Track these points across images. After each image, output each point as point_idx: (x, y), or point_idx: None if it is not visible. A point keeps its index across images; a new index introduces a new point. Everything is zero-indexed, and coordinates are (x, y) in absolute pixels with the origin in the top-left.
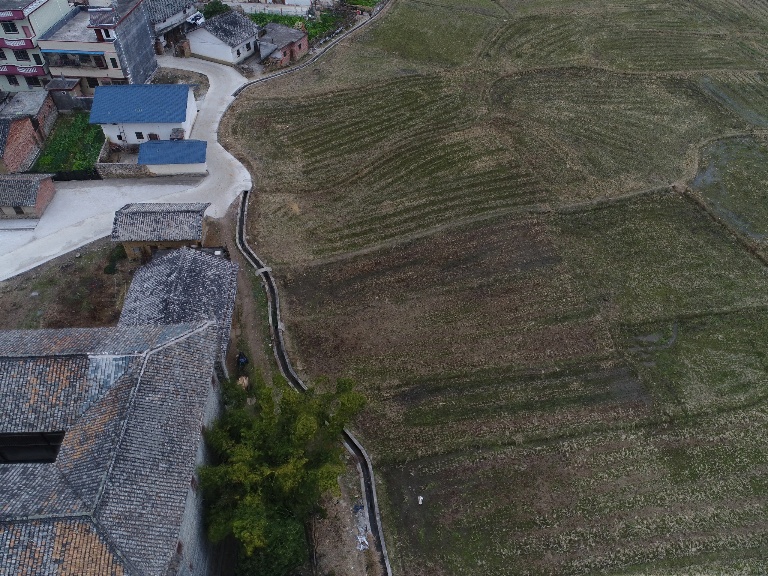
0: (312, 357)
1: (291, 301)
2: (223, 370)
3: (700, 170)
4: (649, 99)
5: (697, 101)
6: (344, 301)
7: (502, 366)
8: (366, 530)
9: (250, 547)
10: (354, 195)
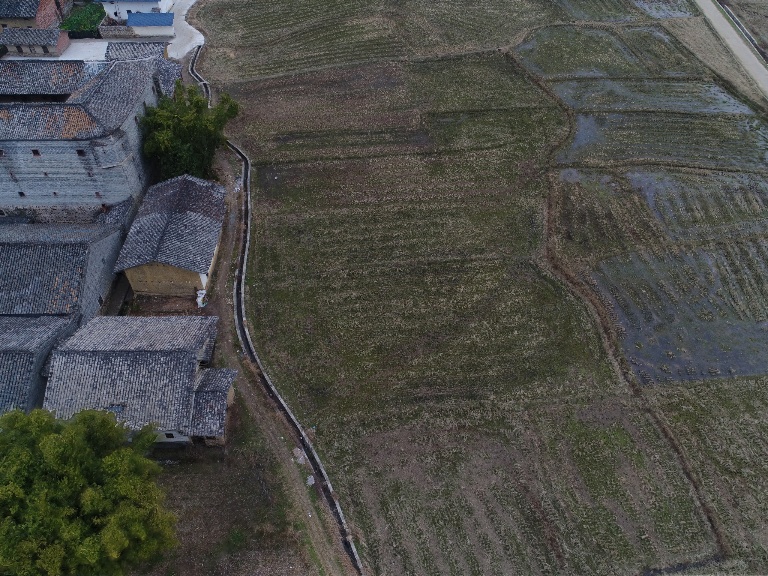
0: (227, 122)
1: (219, 98)
2: (159, 86)
3: (524, 42)
4: (508, 4)
5: (544, 5)
6: (253, 99)
7: (345, 128)
8: (240, 185)
9: (163, 145)
10: (274, 50)
